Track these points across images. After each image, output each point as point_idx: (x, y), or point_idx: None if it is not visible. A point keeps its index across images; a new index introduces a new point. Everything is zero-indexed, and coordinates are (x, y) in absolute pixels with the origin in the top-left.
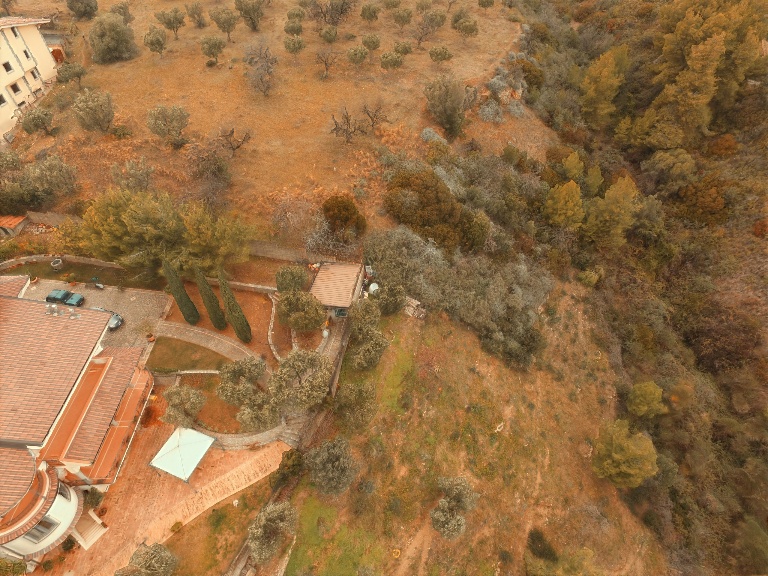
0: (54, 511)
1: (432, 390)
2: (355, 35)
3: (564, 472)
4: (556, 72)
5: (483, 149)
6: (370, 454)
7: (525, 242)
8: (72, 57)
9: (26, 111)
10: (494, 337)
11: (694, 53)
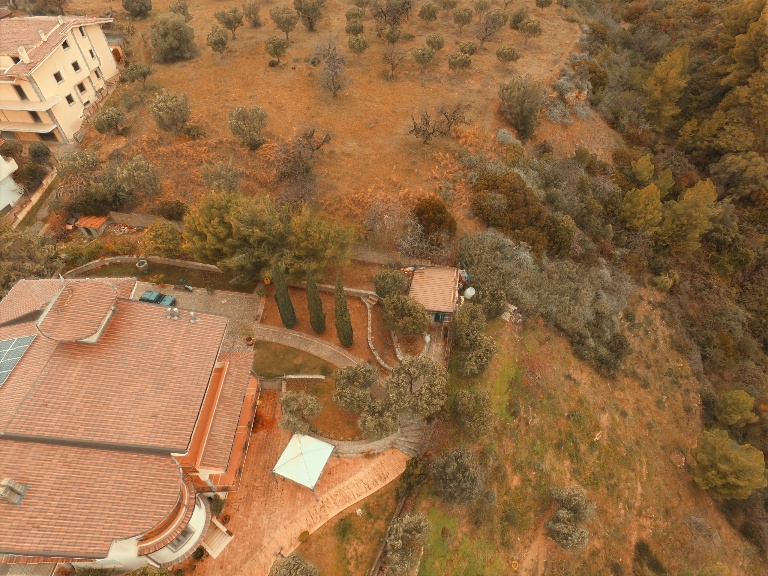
0: (191, 519)
1: (534, 397)
2: (414, 35)
3: (662, 482)
4: (617, 73)
5: (554, 151)
6: (487, 463)
7: (604, 246)
8: (131, 57)
9: (99, 111)
10: (587, 343)
11: None
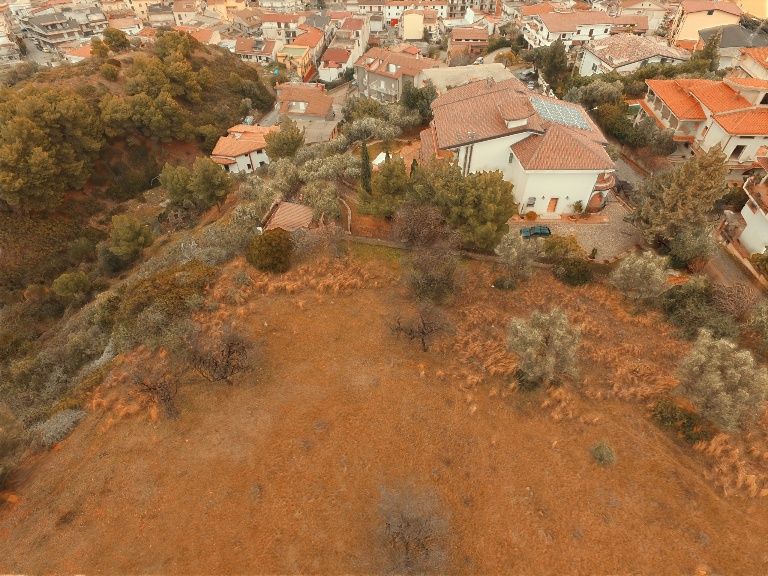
0: None
1: None
2: None
3: None
4: None
5: None
6: None
7: None
8: None
9: None
10: None
11: None
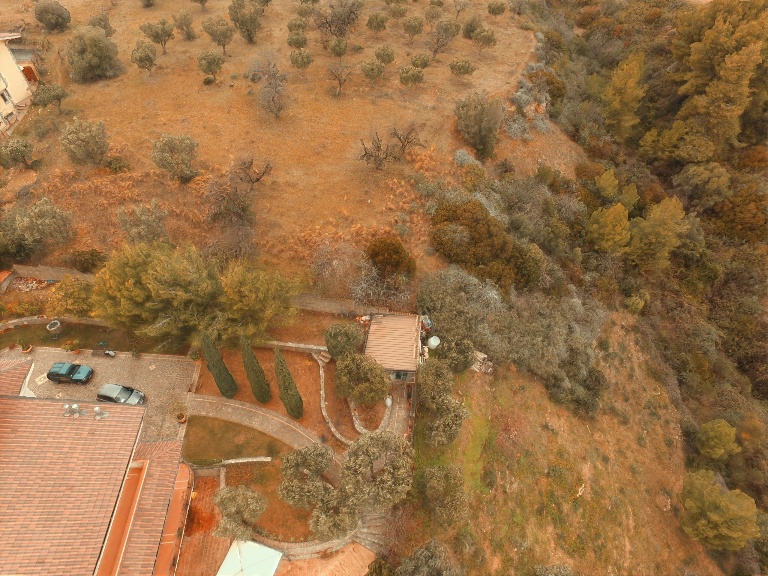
0: None
1: (511, 458)
2: (362, 47)
3: (649, 533)
4: (575, 83)
5: (515, 169)
6: (463, 551)
7: (574, 272)
8: (46, 76)
9: (1, 143)
10: (563, 386)
11: (729, 63)
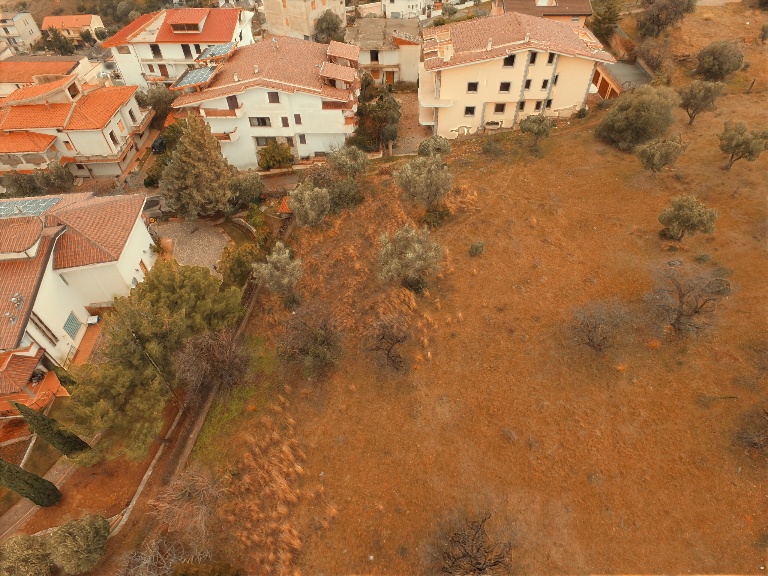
0: None
1: None
2: None
3: None
4: None
5: None
6: None
7: None
8: (603, 110)
9: None
10: None
11: None
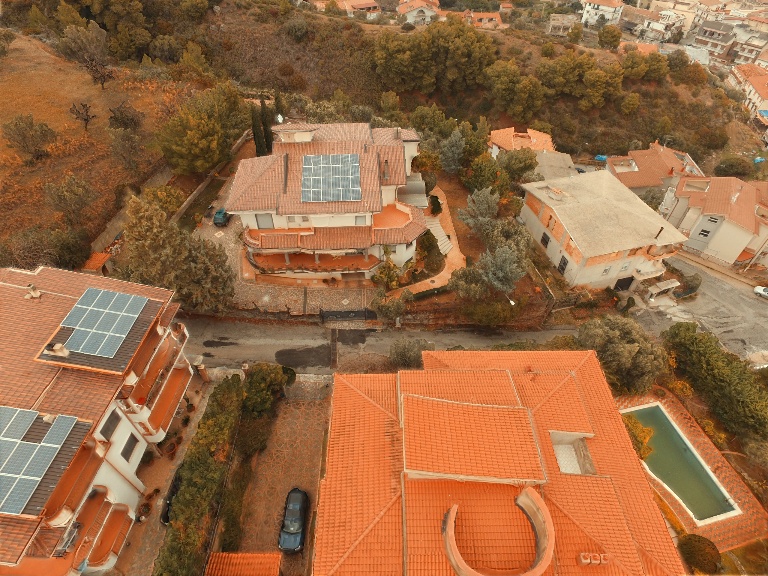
0: None
1: None
2: None
3: None
4: None
5: None
6: None
7: None
8: None
9: None
10: None
11: None
